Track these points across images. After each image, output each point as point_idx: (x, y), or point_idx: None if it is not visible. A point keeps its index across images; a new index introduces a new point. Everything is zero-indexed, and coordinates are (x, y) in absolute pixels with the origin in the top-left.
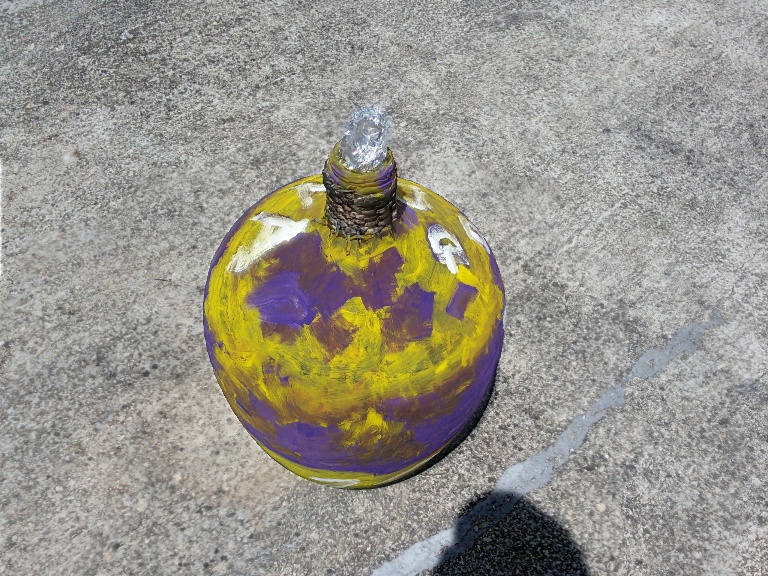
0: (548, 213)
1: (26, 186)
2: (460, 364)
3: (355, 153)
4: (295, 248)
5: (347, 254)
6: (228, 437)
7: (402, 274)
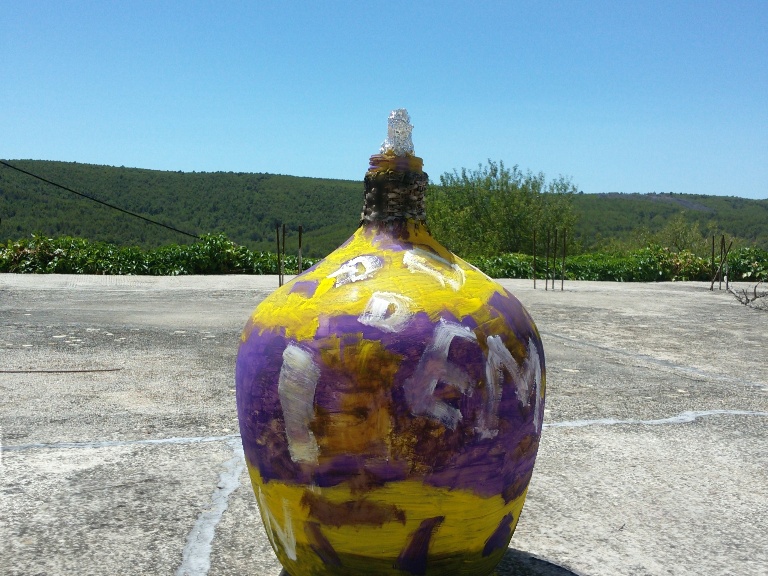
0: None
1: None
2: None
3: None
4: None
5: None
6: None
7: None
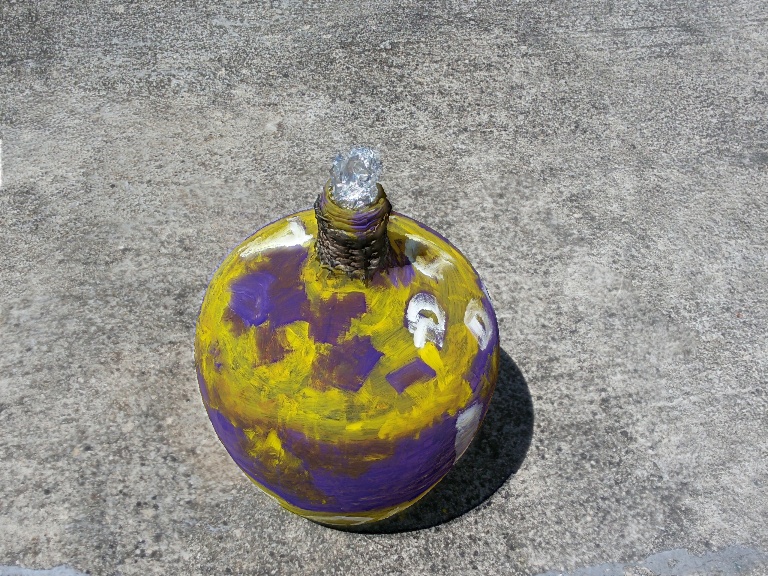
0: (667, 362)
1: (223, 135)
2: (376, 433)
3: (340, 185)
4: (286, 255)
5: (317, 279)
6: None
7: (359, 322)
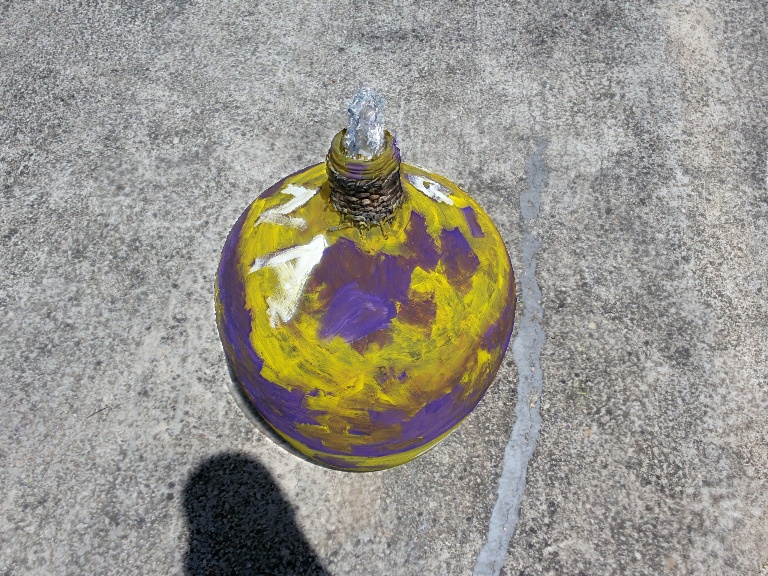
0: None
1: None
2: (506, 271)
3: (368, 143)
4: (332, 264)
5: (385, 239)
6: (293, 489)
7: (429, 228)
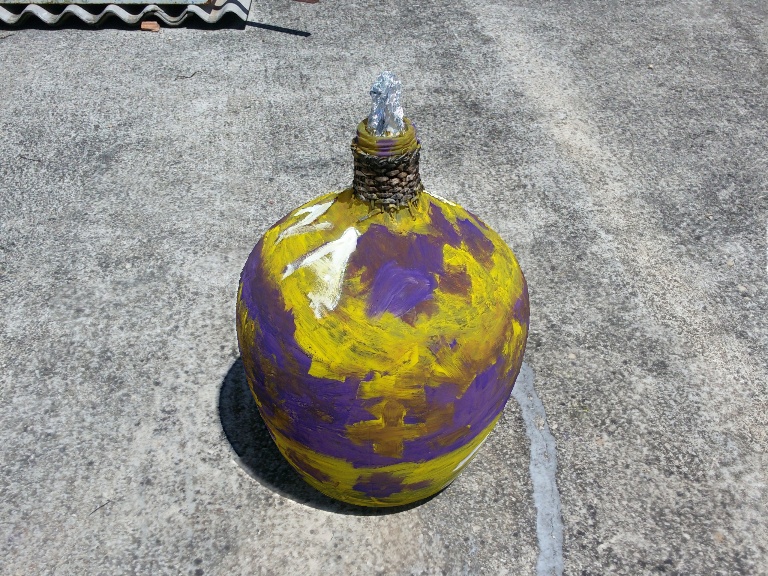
0: None
1: None
2: None
3: (395, 119)
4: (369, 249)
5: (413, 220)
6: (330, 541)
7: (445, 216)
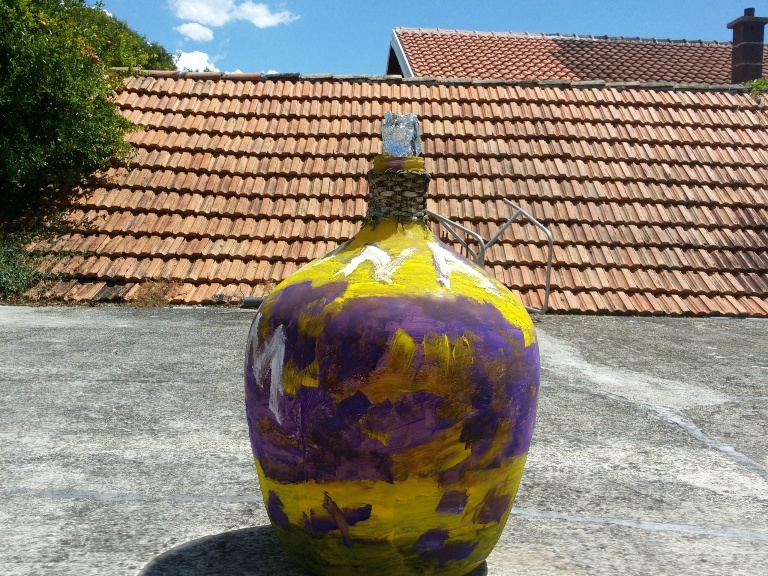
0: None
1: None
2: None
3: None
4: None
5: None
6: None
7: None
